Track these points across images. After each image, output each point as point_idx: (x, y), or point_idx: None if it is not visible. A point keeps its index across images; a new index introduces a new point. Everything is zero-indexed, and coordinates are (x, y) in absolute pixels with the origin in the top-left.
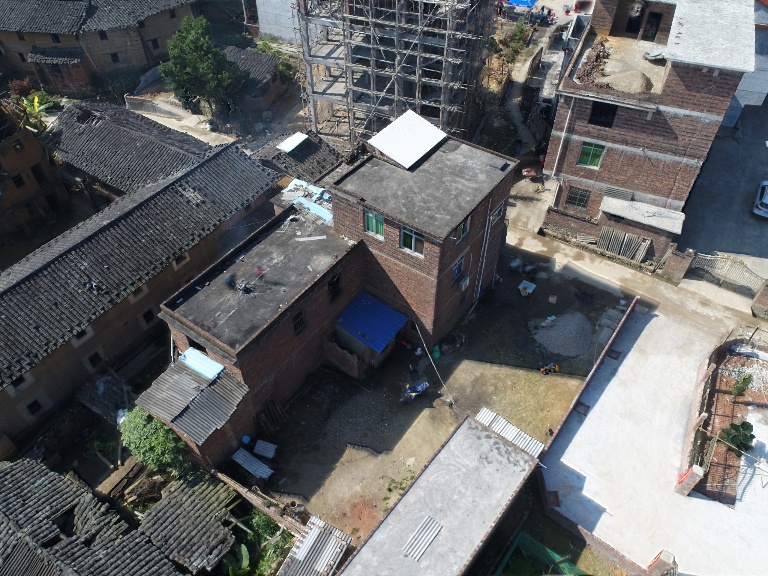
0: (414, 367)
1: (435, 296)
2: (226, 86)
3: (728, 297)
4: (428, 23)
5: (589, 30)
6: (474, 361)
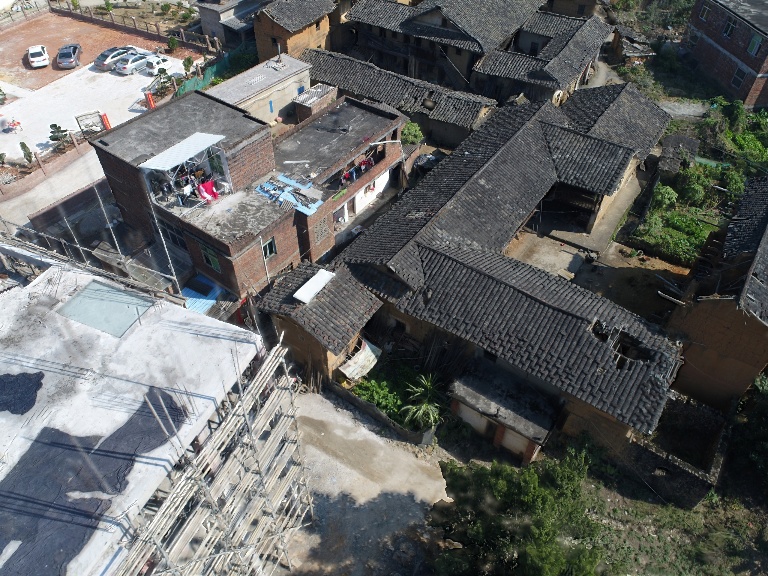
0: None
1: None
2: None
3: None
4: None
5: None
6: None
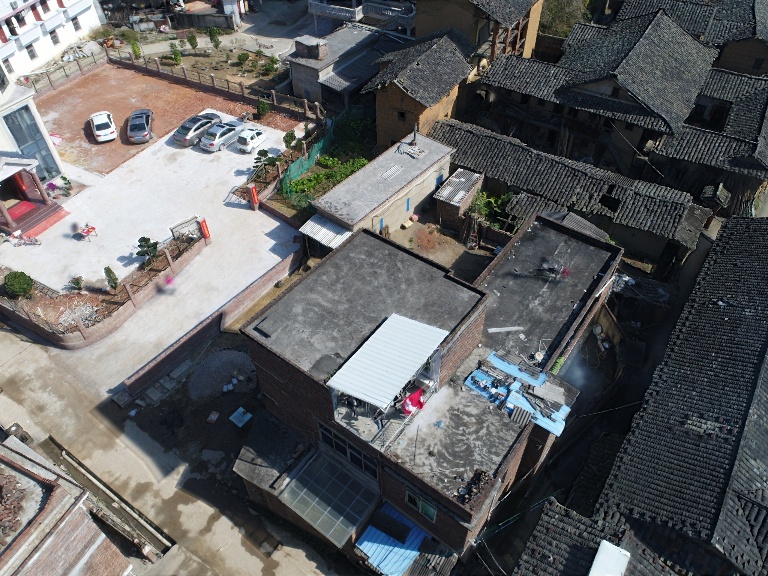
0: None
1: None
2: None
3: (5, 414)
4: None
5: None
6: None
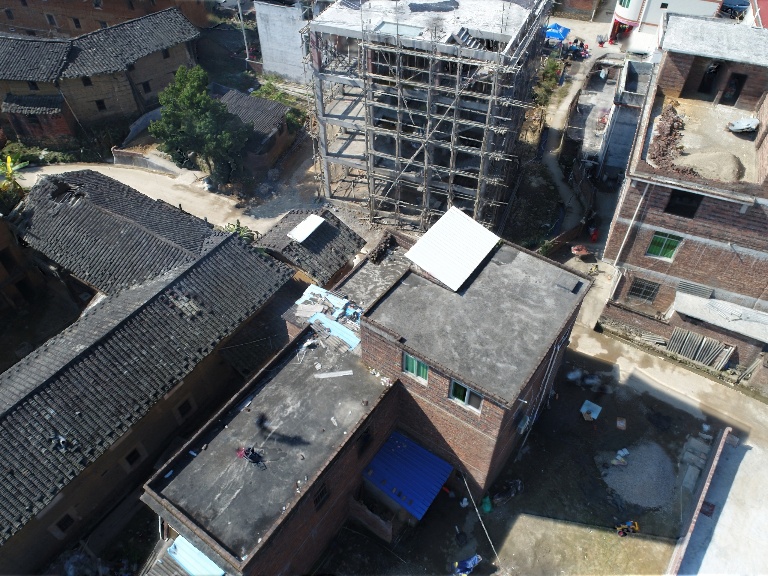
0: (460, 525)
1: (492, 455)
2: (226, 148)
3: None
4: (467, 86)
5: (655, 91)
6: (533, 516)
